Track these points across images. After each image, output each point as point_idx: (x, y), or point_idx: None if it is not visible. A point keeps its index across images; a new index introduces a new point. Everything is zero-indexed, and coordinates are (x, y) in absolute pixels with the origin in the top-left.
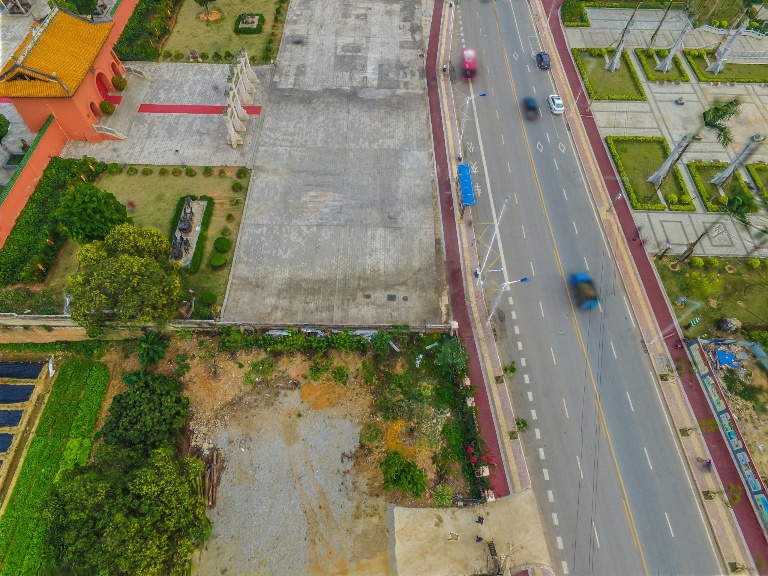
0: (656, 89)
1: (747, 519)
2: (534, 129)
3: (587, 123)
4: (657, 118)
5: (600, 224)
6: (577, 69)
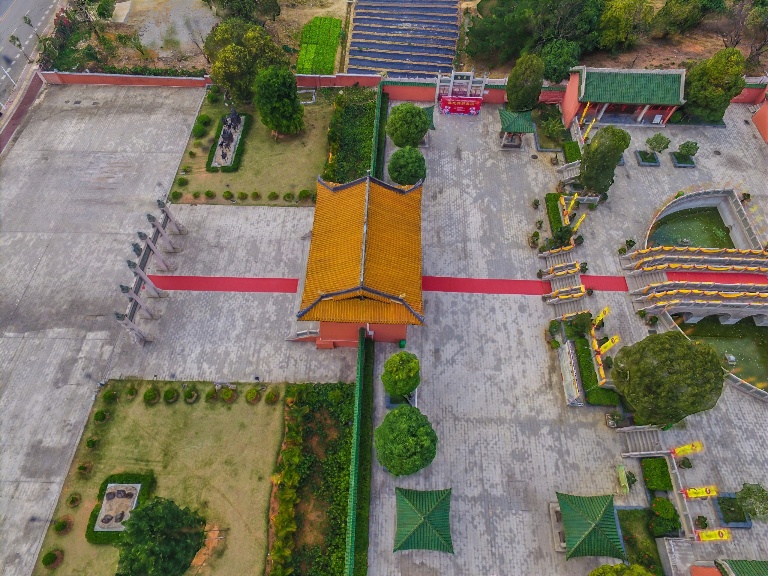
0: None
1: None
2: None
3: None
4: None
5: None
6: None
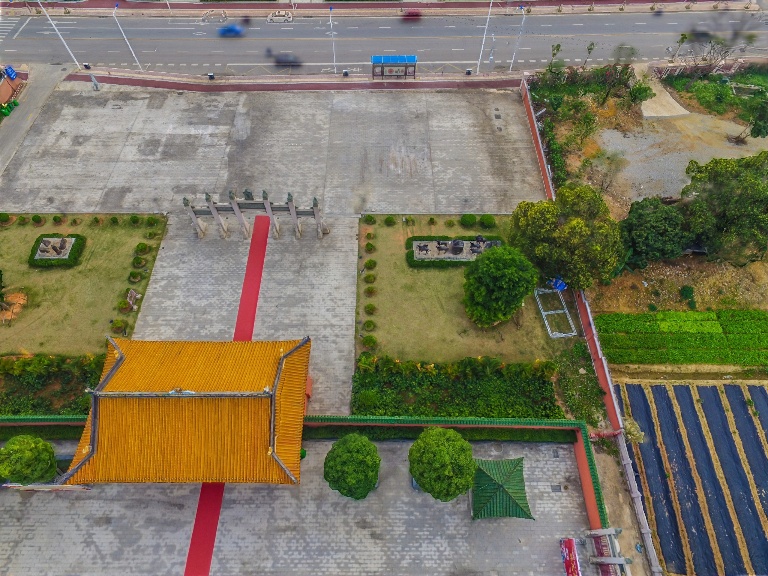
0: None
1: (597, 2)
2: (309, 34)
3: (305, 7)
4: None
5: (413, 17)
6: (232, 2)
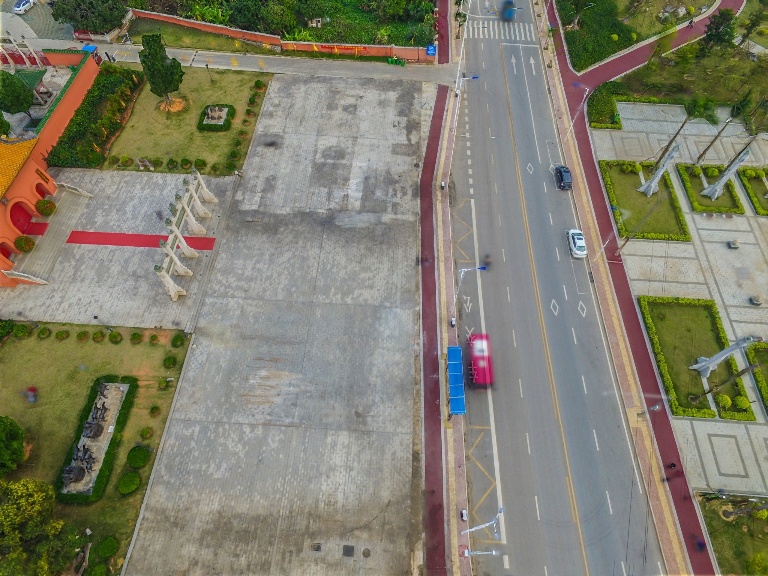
0: (703, 224)
1: None
2: (548, 279)
3: (615, 273)
4: (704, 268)
5: (629, 435)
6: (605, 191)
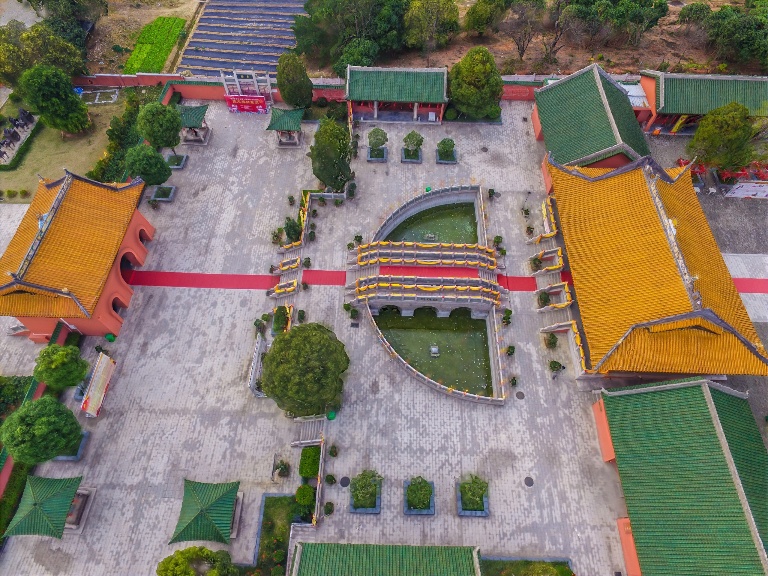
0: None
1: None
2: None
3: None
4: None
5: None
6: None
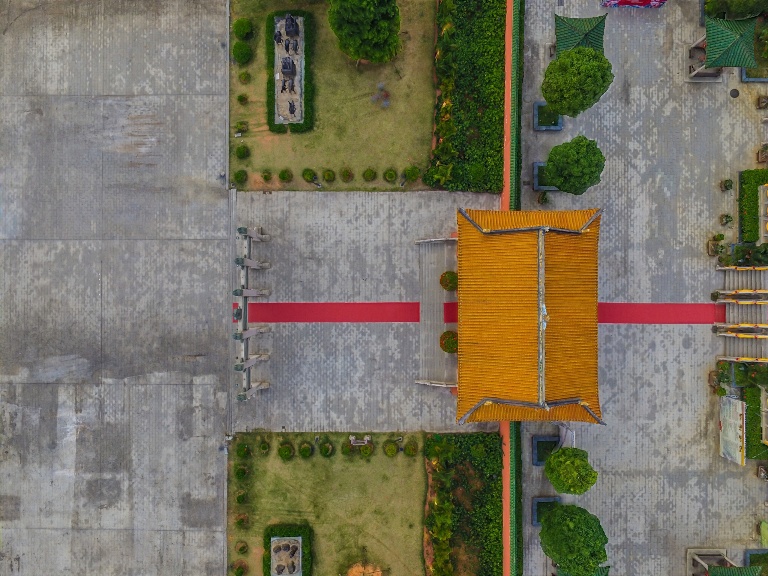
0: None
1: None
2: None
3: None
4: None
5: None
6: None
